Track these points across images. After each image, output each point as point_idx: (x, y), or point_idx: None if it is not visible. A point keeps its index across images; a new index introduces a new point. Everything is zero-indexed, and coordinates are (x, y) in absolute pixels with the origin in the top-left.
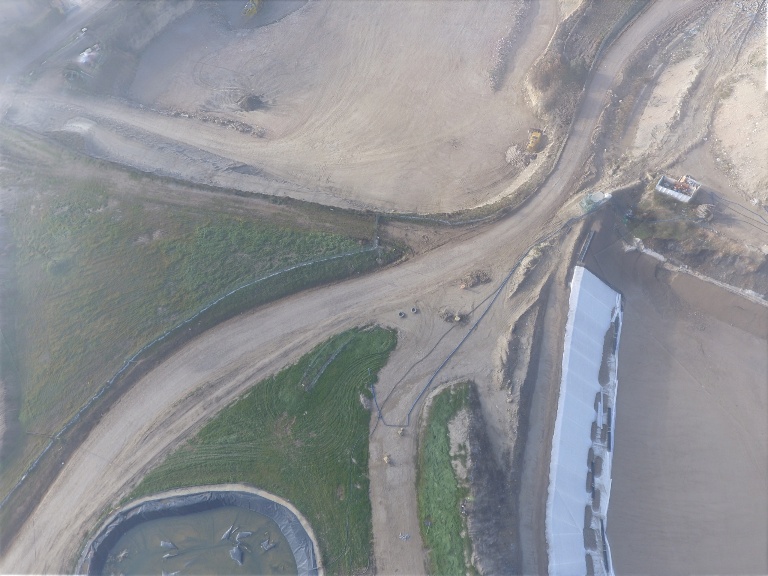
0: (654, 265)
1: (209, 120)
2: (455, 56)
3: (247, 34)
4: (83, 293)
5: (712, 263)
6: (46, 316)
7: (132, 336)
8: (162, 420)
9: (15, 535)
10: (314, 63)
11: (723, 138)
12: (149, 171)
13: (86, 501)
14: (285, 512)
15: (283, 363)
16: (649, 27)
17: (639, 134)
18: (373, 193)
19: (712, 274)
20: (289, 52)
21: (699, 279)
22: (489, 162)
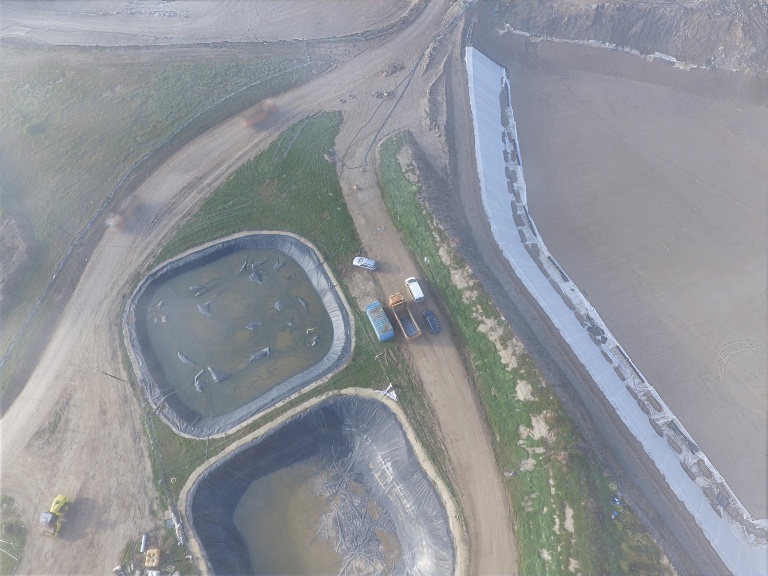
0: (523, 41)
1: (136, 13)
2: None
3: None
4: (64, 142)
5: (562, 28)
6: (35, 165)
7: (119, 162)
8: (165, 209)
9: (60, 316)
10: None
11: None
12: None
13: (116, 277)
14: (286, 238)
15: (256, 151)
16: None
17: None
18: None
19: (564, 36)
20: None
21: (556, 42)
22: (384, 1)
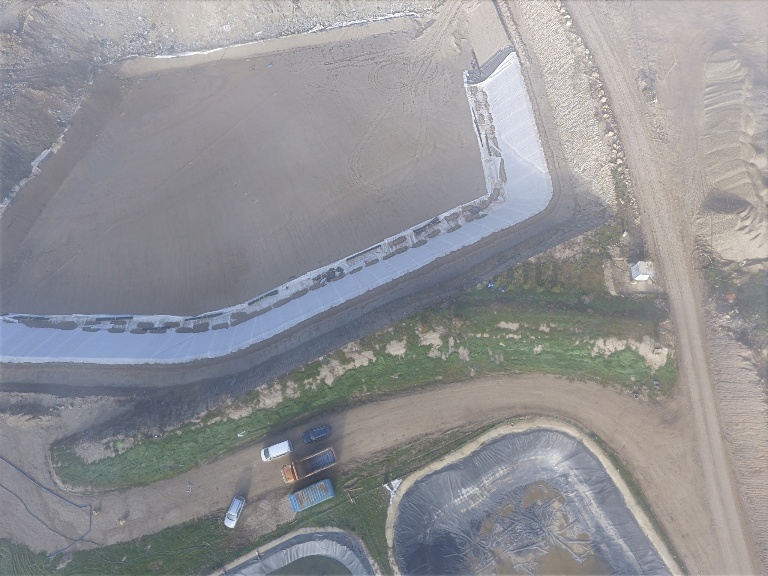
0: None
1: None
2: None
3: None
4: None
5: None
6: None
7: None
8: None
9: None
10: None
11: None
12: None
13: None
14: None
15: None
16: None
17: None
18: None
19: None
20: None
21: None
22: None
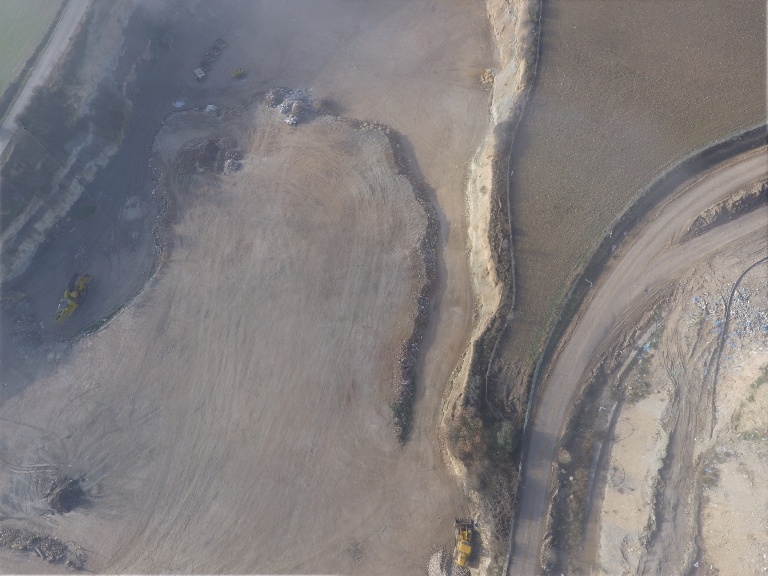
0: None
1: (3, 544)
2: (345, 379)
3: (62, 355)
4: None
5: None
6: None
7: None
8: None
9: None
10: (155, 406)
11: (720, 566)
12: None
13: None
14: None
15: None
16: (591, 343)
17: (604, 542)
18: None
19: None
20: (120, 386)
21: None
22: None
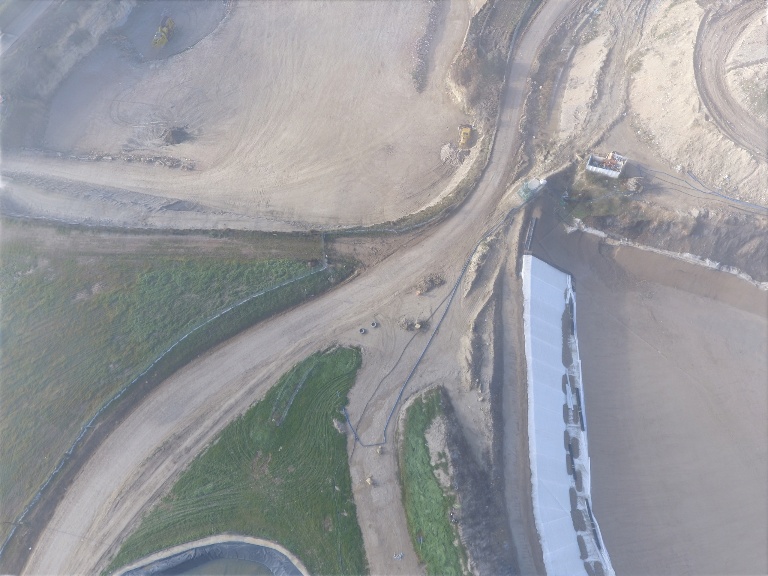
0: (597, 242)
1: (134, 159)
2: (376, 62)
3: (161, 65)
4: (25, 363)
5: (649, 232)
6: None
7: (85, 400)
8: (131, 483)
9: None
10: (235, 86)
11: (640, 111)
12: (77, 223)
13: None
14: (275, 555)
15: (249, 401)
16: (556, 12)
17: (563, 117)
18: (315, 211)
19: (651, 243)
20: (208, 78)
21: (640, 249)
22: (425, 164)
